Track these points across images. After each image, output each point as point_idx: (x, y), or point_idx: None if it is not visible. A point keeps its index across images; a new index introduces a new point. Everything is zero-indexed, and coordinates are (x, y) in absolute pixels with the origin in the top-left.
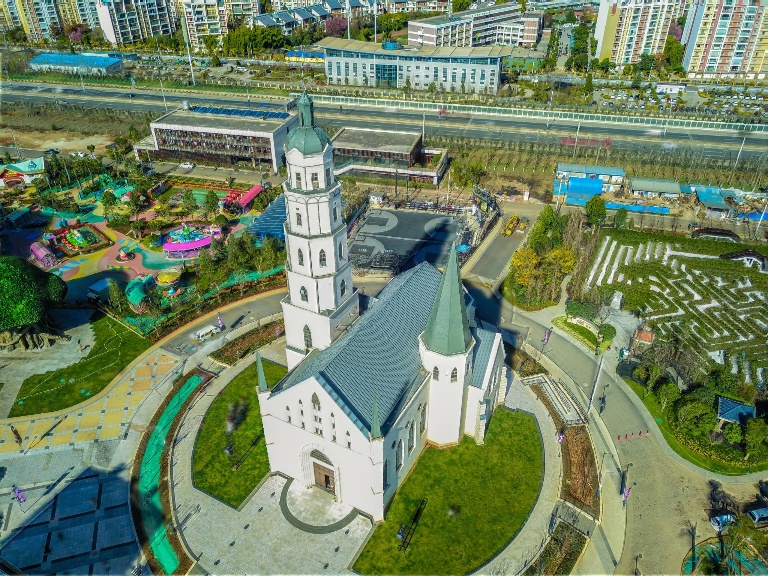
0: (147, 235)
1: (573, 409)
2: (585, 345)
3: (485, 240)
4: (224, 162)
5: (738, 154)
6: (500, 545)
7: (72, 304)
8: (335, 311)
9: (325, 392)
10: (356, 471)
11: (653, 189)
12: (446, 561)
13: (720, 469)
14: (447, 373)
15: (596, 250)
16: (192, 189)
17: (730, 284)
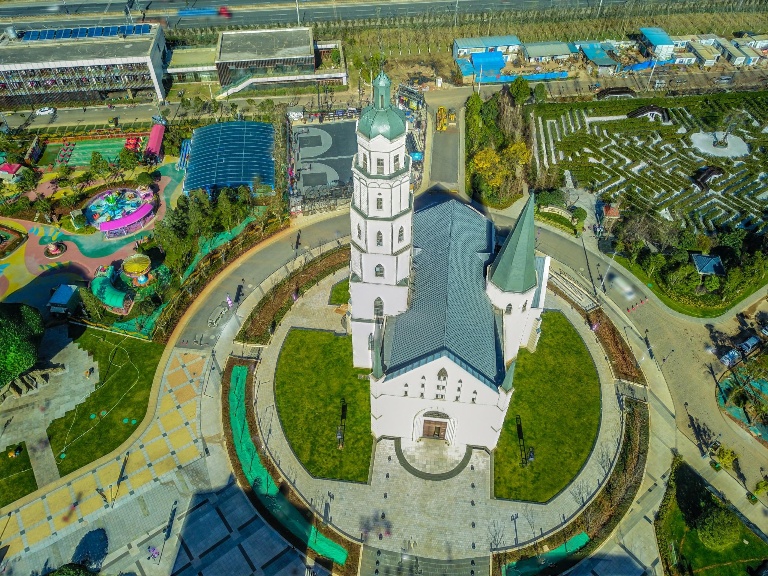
0: (62, 216)
1: (584, 295)
2: (564, 231)
3: (426, 141)
4: (92, 99)
5: (600, 2)
6: (593, 434)
7: None
8: (409, 278)
9: (457, 365)
10: (474, 417)
11: (547, 54)
12: (562, 462)
13: (708, 314)
14: (520, 306)
15: (530, 131)
16: (74, 143)
17: (647, 142)
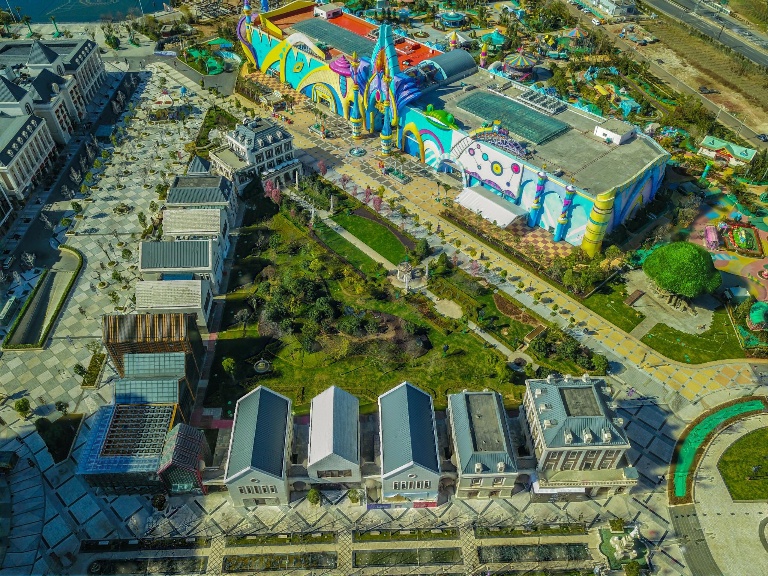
0: None
1: None
2: None
3: None
4: None
5: None
6: None
7: None
8: None
9: None
10: None
11: None
12: None
13: None
14: None
15: None
16: None
17: None
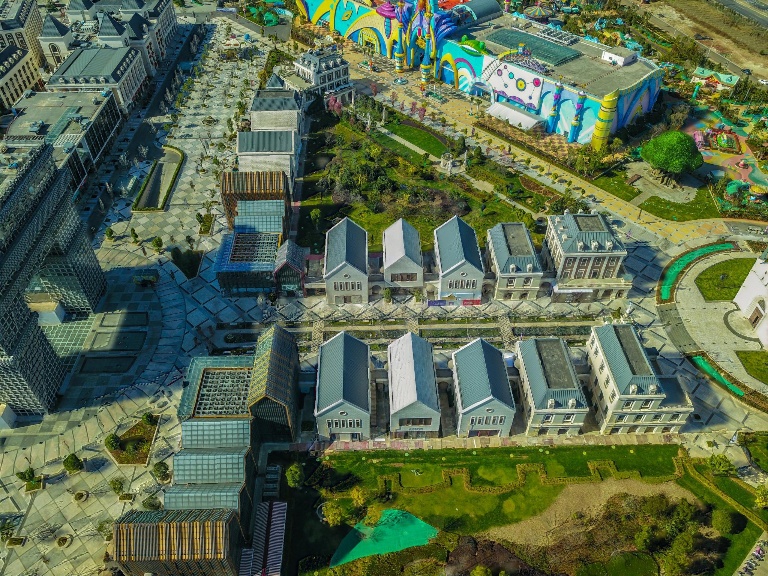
0: (765, 159)
1: None
2: None
3: None
4: None
5: None
6: None
7: (696, 174)
8: None
9: None
10: None
11: None
12: None
13: None
14: None
15: None
16: None
17: None
